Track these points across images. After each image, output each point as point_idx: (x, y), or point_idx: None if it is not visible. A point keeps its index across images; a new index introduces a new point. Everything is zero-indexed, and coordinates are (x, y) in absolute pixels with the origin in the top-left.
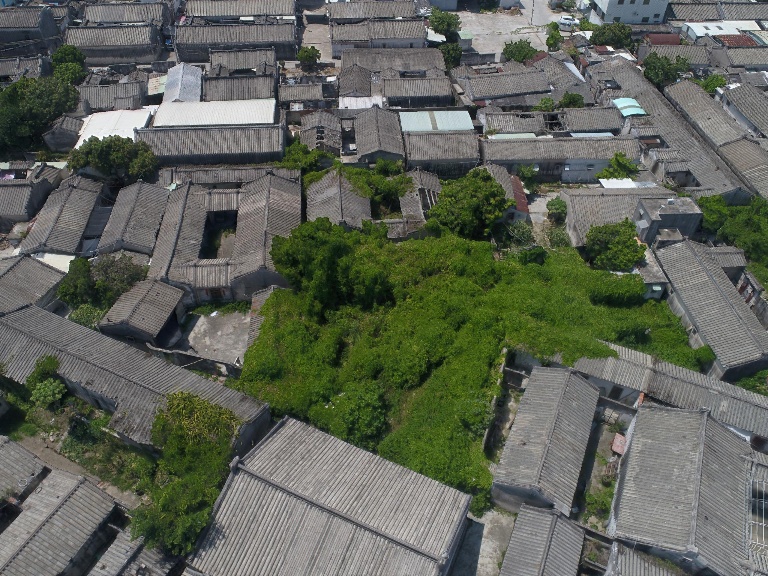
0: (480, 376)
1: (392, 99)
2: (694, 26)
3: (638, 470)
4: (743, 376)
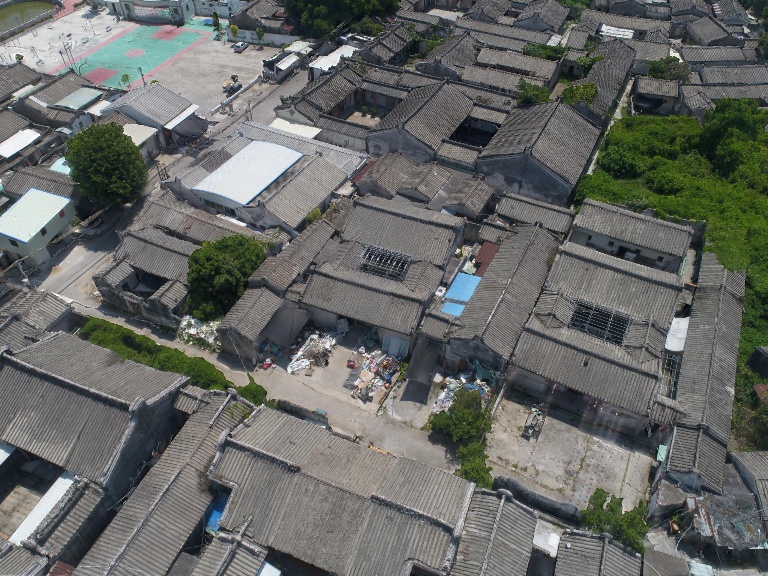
0: (671, 206)
1: None
2: None
3: None
4: (760, 372)
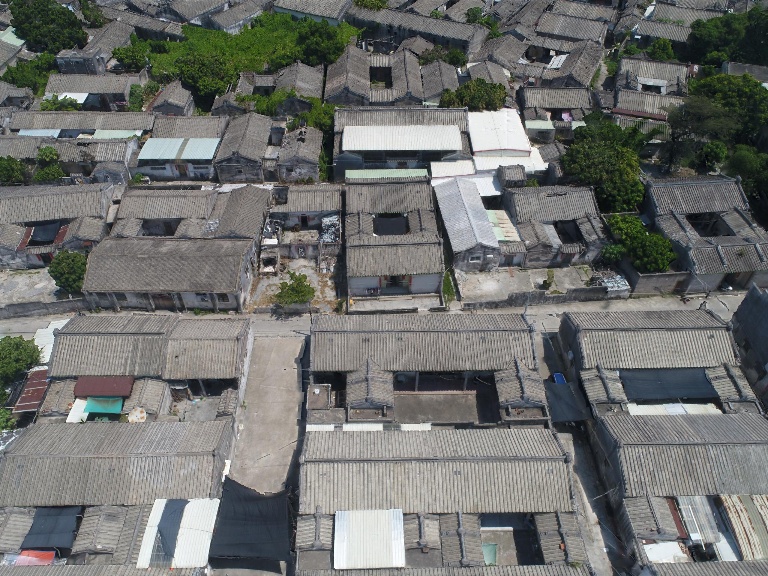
0: None
1: None
2: None
3: (207, 8)
4: None
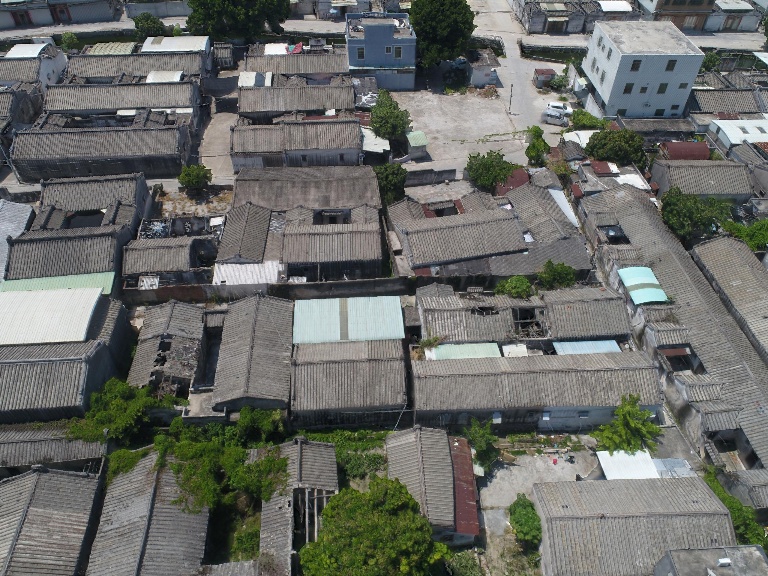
0: None
1: (294, 265)
2: (727, 127)
3: None
4: None
